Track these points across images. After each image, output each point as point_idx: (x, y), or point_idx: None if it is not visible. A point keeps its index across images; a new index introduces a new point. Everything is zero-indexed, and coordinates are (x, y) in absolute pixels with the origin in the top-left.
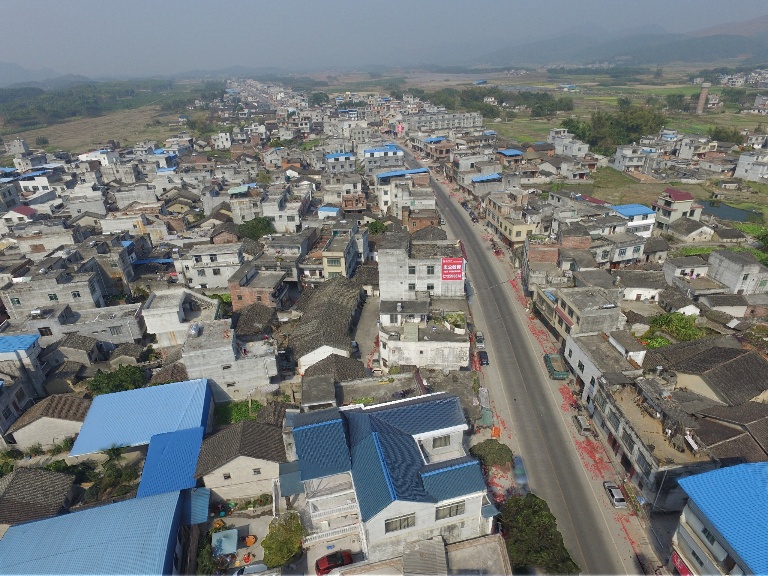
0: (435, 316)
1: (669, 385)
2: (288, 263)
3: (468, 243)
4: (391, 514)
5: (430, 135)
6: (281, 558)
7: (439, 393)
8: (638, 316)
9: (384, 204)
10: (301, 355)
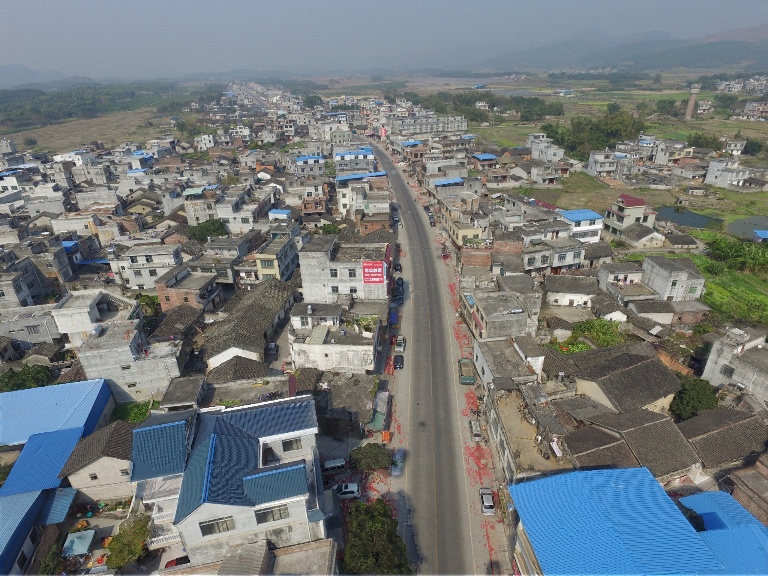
0: (346, 319)
1: (568, 391)
2: (223, 265)
3: (419, 247)
4: (204, 517)
5: (408, 139)
6: (121, 560)
7: (304, 396)
8: (561, 322)
9: (343, 207)
10: (210, 357)
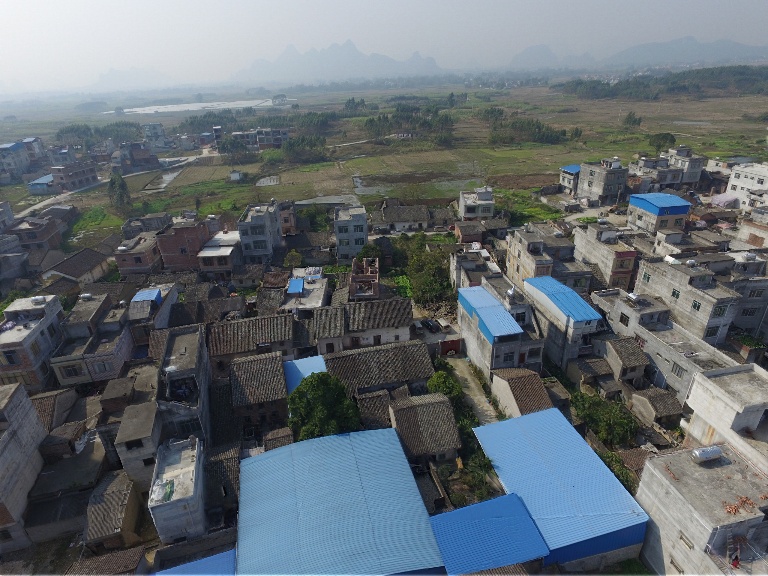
0: None
1: None
2: None
3: None
4: None
5: None
6: None
7: None
8: None
9: None
10: None
